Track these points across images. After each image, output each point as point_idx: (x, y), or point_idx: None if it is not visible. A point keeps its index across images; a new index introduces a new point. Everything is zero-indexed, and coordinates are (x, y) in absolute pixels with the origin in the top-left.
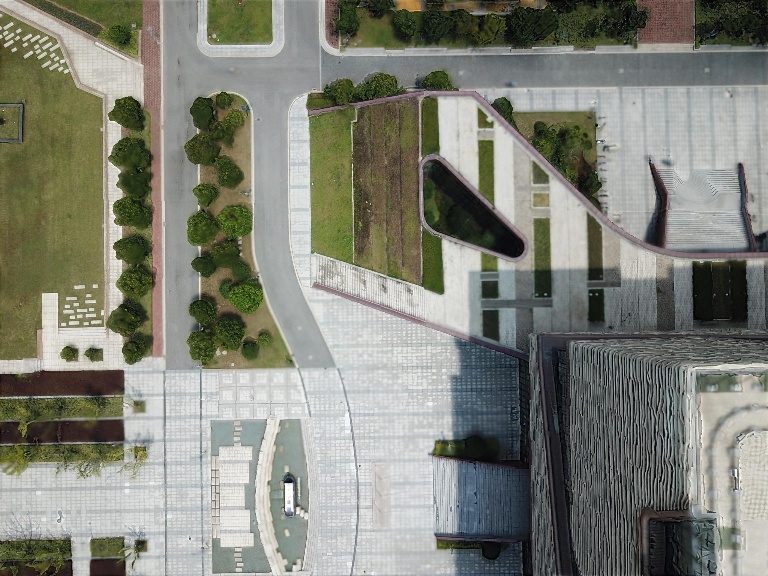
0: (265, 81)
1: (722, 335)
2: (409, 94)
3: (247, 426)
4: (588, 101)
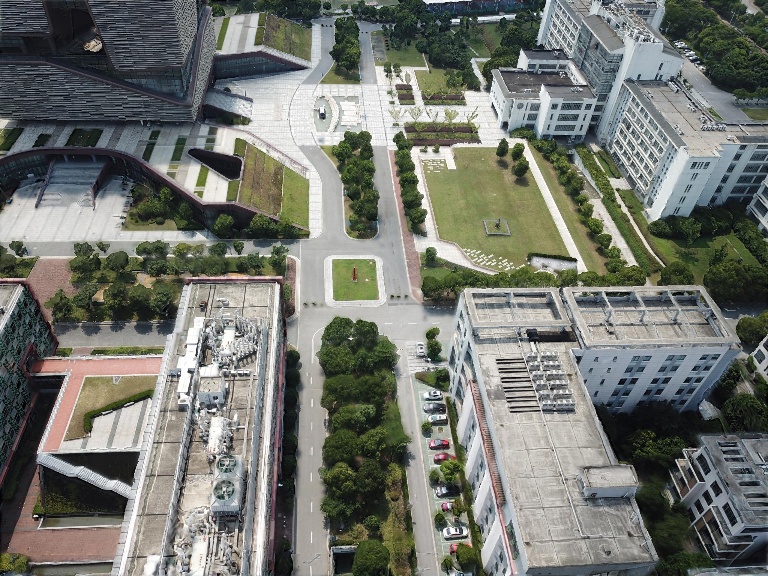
0: (337, 245)
1: (107, 82)
2: (243, 207)
3: (344, 131)
4: (124, 235)
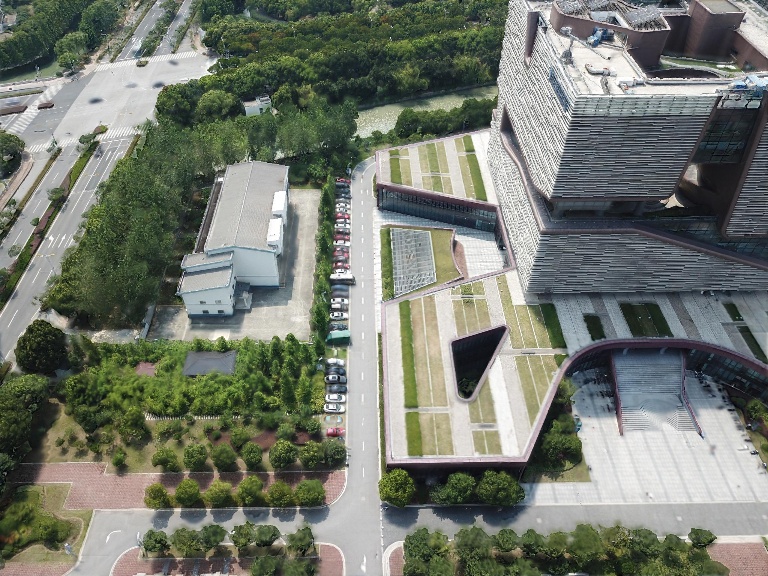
0: None
1: (701, 250)
2: None
3: None
4: None
